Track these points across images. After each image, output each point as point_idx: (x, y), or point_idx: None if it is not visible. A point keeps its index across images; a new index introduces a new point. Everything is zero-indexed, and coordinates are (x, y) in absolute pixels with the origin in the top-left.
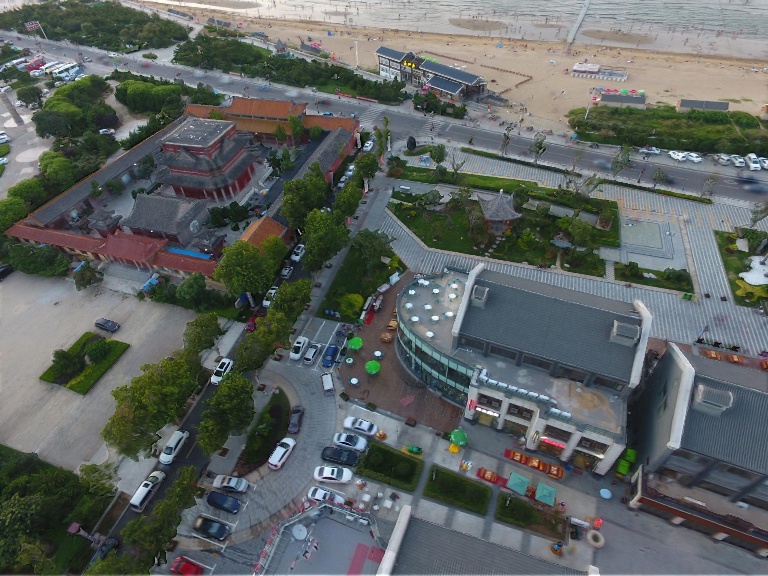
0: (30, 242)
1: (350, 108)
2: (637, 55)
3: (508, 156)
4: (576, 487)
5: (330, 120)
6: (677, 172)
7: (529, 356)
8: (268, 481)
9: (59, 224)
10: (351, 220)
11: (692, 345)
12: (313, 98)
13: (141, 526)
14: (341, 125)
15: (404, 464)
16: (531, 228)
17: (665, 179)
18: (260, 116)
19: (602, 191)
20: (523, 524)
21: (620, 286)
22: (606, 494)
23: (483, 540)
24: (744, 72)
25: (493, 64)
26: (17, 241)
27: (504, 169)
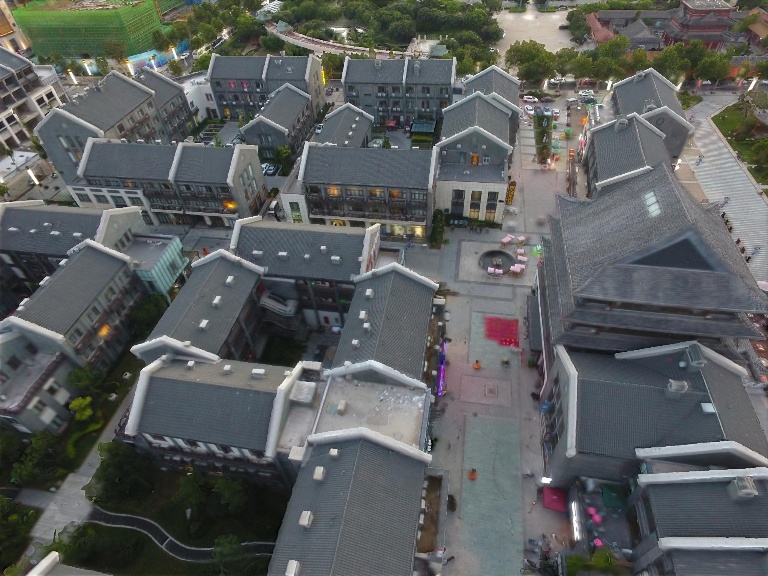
0: (587, 22)
1: None
2: None
3: None
4: None
5: None
6: None
7: None
8: None
9: (606, 24)
10: (708, 92)
11: None
12: None
13: None
14: None
15: None
16: None
17: None
18: None
19: None
20: (539, 152)
21: (755, 190)
22: None
23: None
24: None
25: None
26: (584, 20)
27: None
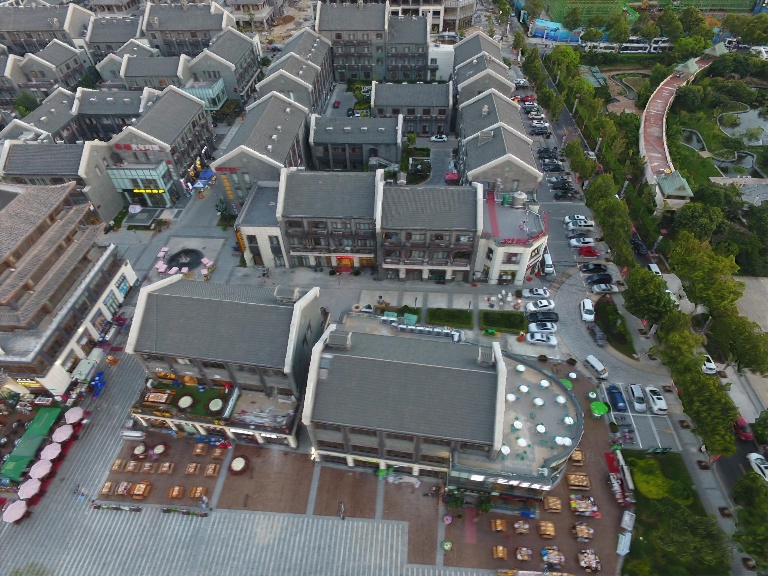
0: None
1: None
2: None
3: None
4: None
5: None
6: None
7: None
8: (582, 297)
9: None
10: None
11: (215, 508)
12: None
13: (623, 225)
14: None
15: (494, 316)
16: None
17: None
18: None
19: None
20: None
21: None
22: None
23: (435, 228)
24: None
25: None
26: None
27: None
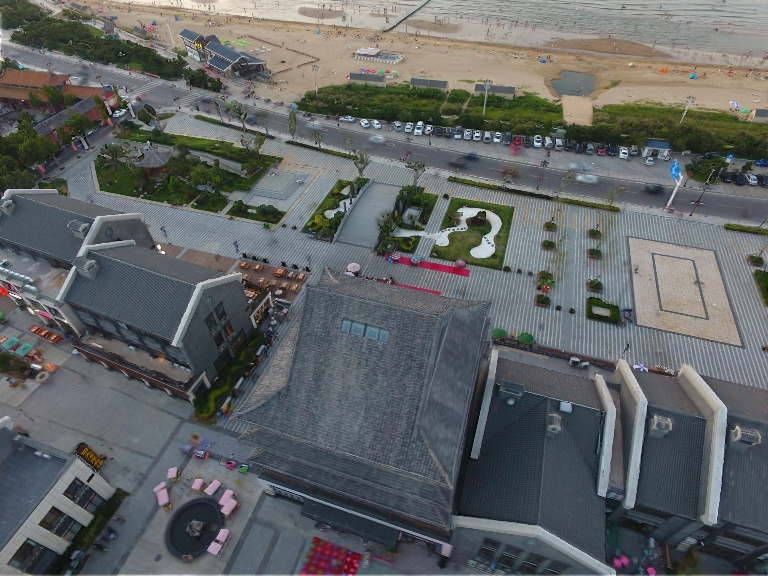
0: None
1: (132, 82)
2: (430, 42)
3: (229, 122)
4: (63, 348)
5: (85, 90)
6: (356, 136)
7: (31, 250)
8: None
9: None
10: (57, 170)
11: (238, 259)
12: (109, 74)
13: None
14: (92, 94)
15: None
16: (190, 176)
17: (322, 139)
18: (24, 85)
19: (260, 147)
20: (2, 370)
21: (224, 219)
22: (76, 351)
23: None
24: (505, 58)
25: (298, 48)
26: None
27: (217, 132)
